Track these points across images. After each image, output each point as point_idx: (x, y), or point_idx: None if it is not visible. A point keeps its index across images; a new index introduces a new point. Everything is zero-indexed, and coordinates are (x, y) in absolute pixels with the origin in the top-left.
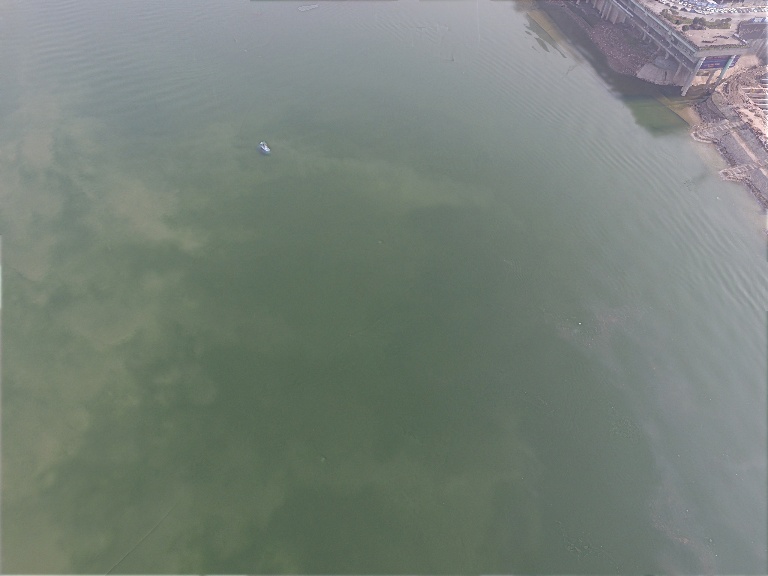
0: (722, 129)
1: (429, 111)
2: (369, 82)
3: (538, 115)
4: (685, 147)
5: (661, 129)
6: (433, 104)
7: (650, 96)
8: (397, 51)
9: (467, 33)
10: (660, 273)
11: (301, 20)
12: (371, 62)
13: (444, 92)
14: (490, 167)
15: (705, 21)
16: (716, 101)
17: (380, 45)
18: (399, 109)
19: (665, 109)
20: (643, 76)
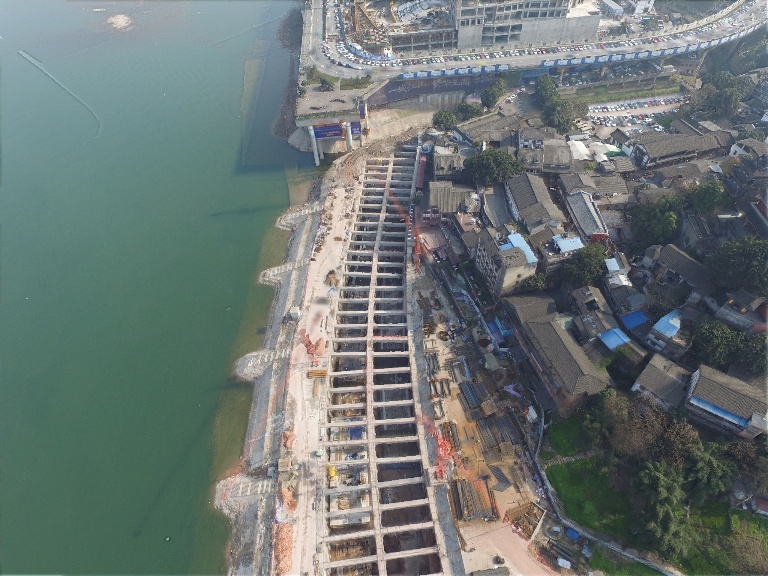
0: (301, 214)
1: (30, 189)
2: (10, 152)
3: (133, 194)
4: (258, 236)
5: (250, 212)
6: (41, 180)
7: (281, 166)
8: (66, 114)
9: (90, 99)
10: (59, 420)
11: (18, 77)
12: (25, 128)
13: (58, 166)
14: (11, 265)
15: (328, 82)
16: (325, 176)
17: (47, 108)
18: (6, 186)
19: (283, 184)
20: (291, 141)
